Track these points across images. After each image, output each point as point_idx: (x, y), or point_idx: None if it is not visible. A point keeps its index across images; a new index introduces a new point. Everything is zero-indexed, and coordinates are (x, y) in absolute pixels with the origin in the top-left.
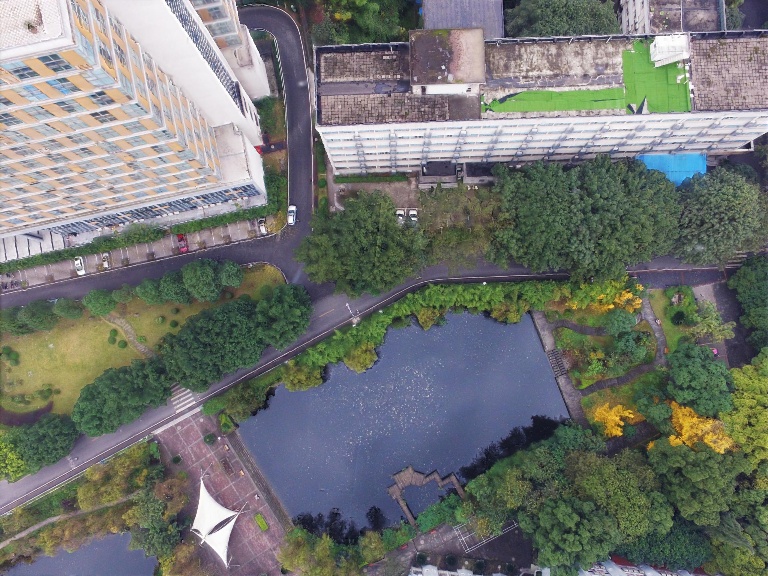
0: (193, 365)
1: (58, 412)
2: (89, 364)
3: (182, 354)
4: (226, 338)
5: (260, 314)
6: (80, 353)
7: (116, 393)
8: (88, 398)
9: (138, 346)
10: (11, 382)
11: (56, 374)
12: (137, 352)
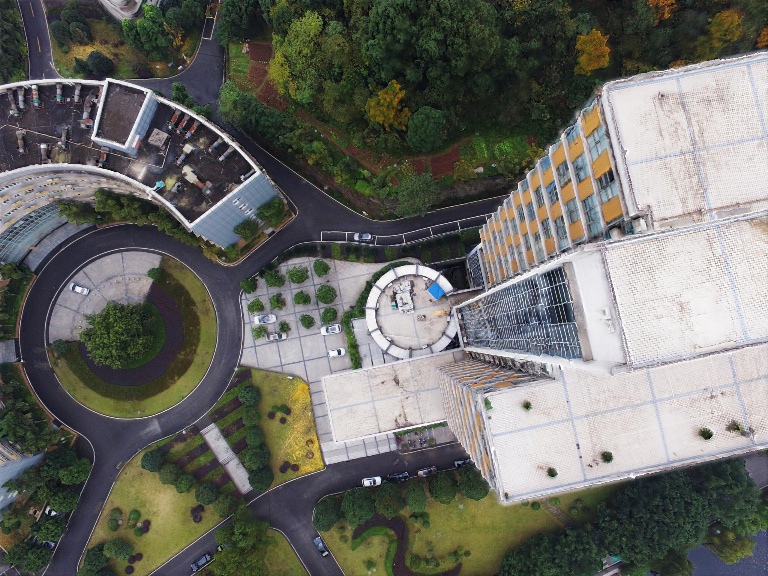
0: (649, 545)
1: (465, 573)
2: (500, 526)
3: (642, 535)
4: (685, 518)
5: (712, 491)
6: (491, 514)
7: (558, 568)
8: (524, 570)
9: (550, 508)
10: (431, 548)
11: (466, 535)
12: (549, 514)
